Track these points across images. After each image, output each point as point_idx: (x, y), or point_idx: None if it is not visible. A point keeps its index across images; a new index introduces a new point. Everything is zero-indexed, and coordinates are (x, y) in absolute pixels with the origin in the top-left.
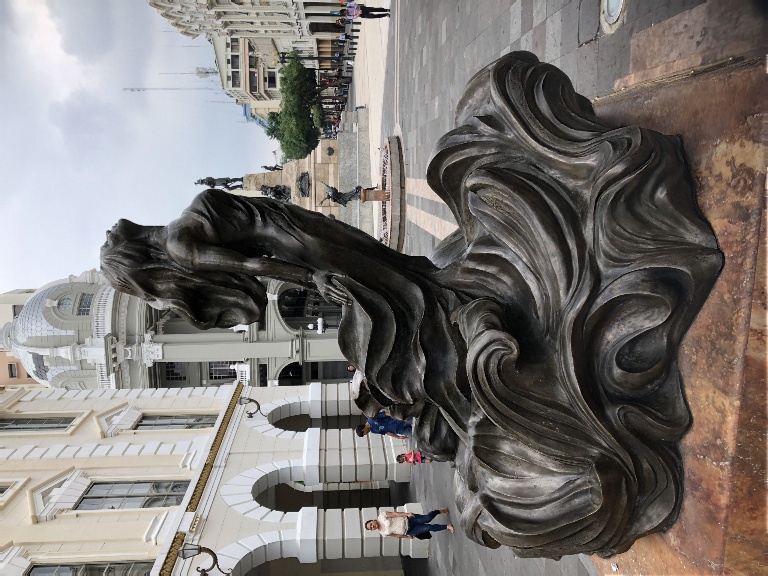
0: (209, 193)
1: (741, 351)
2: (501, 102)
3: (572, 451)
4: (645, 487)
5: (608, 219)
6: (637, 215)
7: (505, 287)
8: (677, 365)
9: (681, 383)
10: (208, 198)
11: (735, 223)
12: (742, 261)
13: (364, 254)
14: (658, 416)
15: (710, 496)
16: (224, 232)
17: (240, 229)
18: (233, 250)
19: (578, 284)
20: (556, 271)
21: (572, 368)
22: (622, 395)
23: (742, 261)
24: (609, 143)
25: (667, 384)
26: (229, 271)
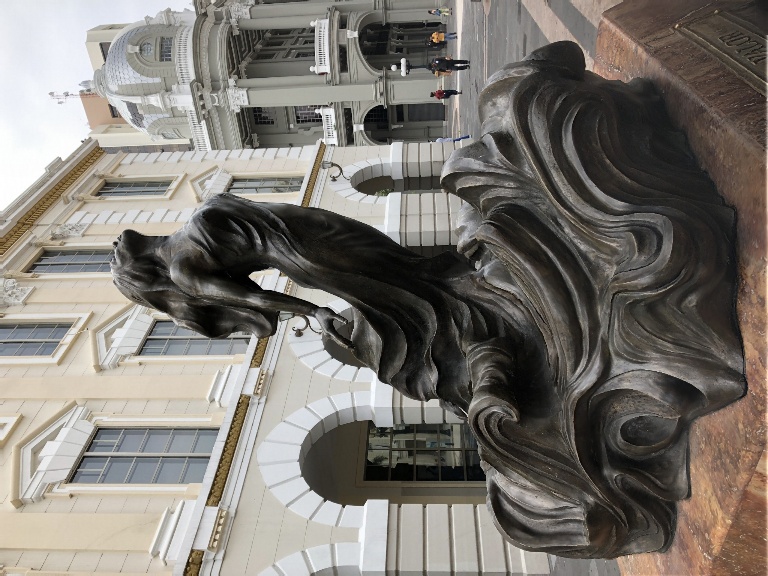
0: (205, 219)
1: (742, 485)
2: (520, 141)
3: (569, 492)
4: (637, 527)
5: (626, 314)
6: (659, 316)
7: (522, 314)
8: (688, 436)
9: (687, 456)
10: (204, 225)
11: (764, 367)
12: (761, 411)
13: (372, 277)
14: (657, 484)
15: (691, 567)
16: (225, 258)
17: (241, 254)
18: (235, 284)
19: (586, 366)
20: (564, 349)
21: (573, 437)
22: (625, 455)
23: (761, 411)
24: (635, 241)
25: (674, 449)
26: (234, 302)
